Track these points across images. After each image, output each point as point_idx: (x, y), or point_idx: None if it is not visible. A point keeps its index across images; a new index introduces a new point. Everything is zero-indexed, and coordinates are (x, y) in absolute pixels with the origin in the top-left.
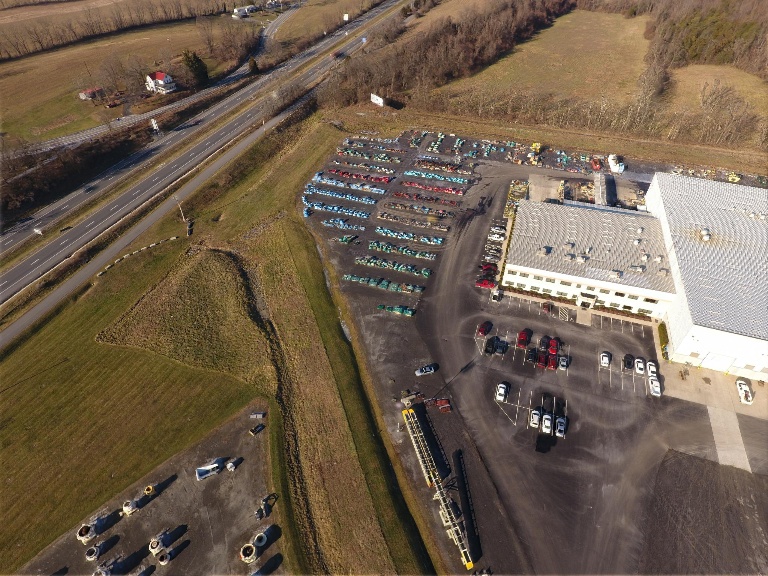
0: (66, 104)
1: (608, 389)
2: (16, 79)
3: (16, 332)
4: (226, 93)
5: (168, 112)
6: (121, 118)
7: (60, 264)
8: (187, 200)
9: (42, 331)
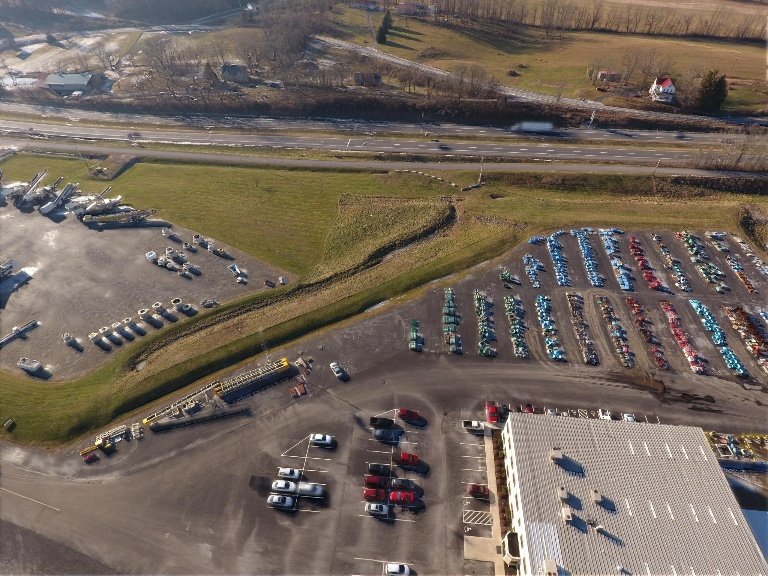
0: (580, 74)
1: (347, 570)
2: (583, 45)
3: (336, 165)
4: (712, 128)
5: (625, 114)
6: (587, 100)
7: (399, 153)
8: (504, 172)
9: (342, 174)
